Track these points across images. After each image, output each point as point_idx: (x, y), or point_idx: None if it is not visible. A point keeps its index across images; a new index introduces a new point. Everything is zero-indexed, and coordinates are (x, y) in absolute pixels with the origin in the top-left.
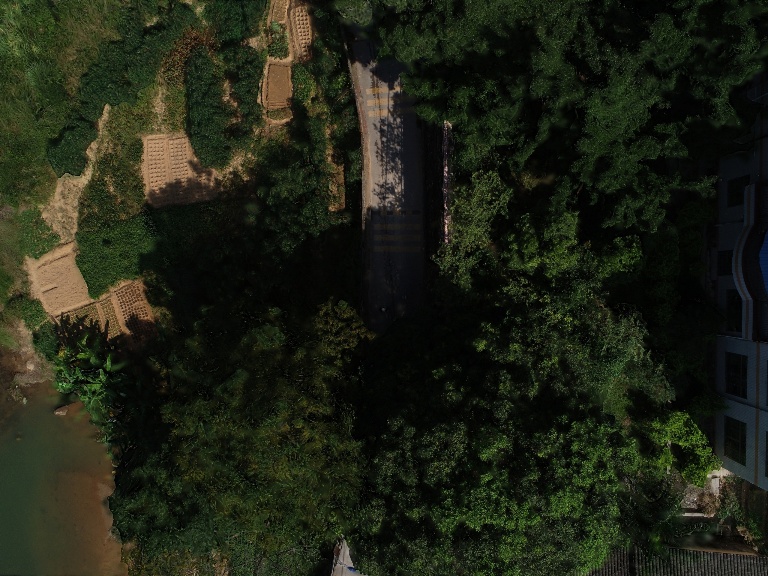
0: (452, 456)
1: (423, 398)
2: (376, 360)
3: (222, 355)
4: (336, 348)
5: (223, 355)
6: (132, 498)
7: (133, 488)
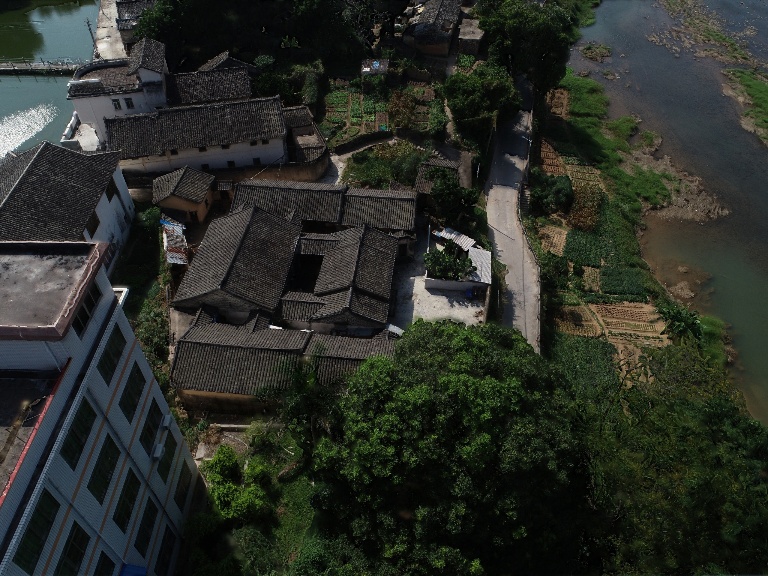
0: (514, 439)
1: (536, 505)
2: (565, 568)
3: (742, 569)
4: (624, 572)
5: (741, 569)
6: (760, 437)
7: (762, 447)
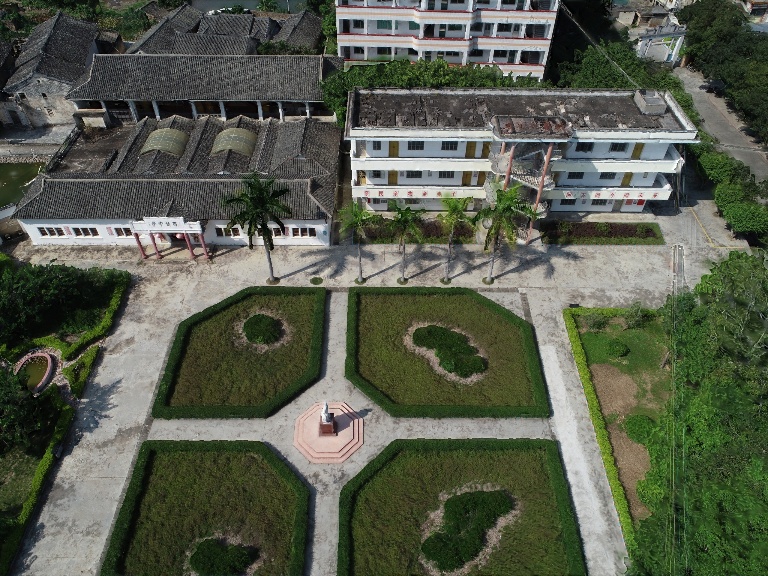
0: None
1: None
2: None
3: None
4: None
5: None
6: None
7: None
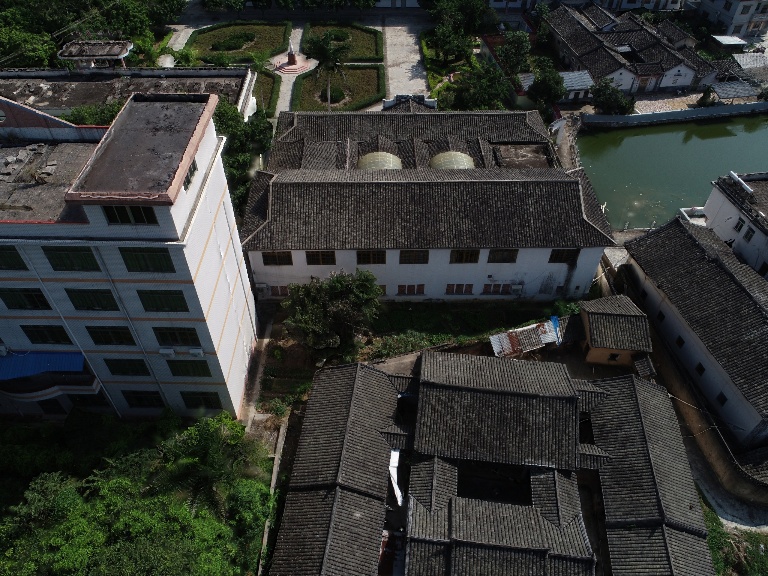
0: None
1: None
2: None
3: None
4: None
5: None
6: None
7: None
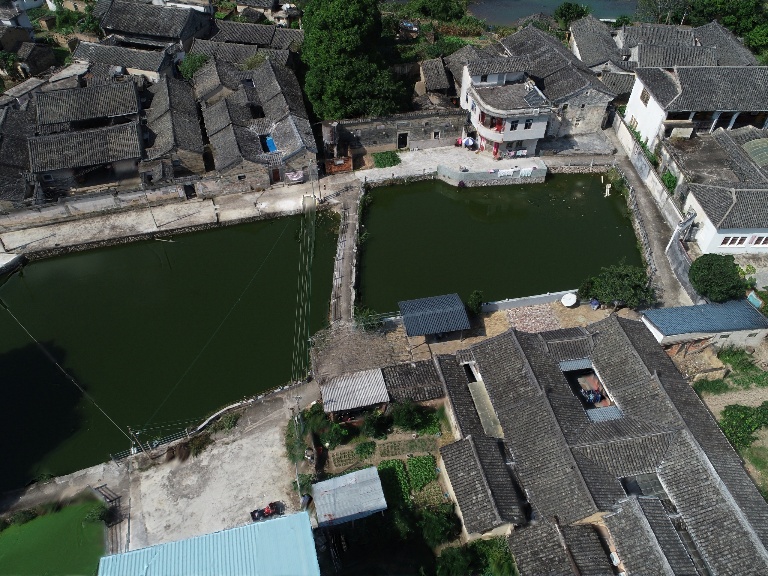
0: None
1: None
2: None
3: None
4: None
5: None
6: None
7: None
